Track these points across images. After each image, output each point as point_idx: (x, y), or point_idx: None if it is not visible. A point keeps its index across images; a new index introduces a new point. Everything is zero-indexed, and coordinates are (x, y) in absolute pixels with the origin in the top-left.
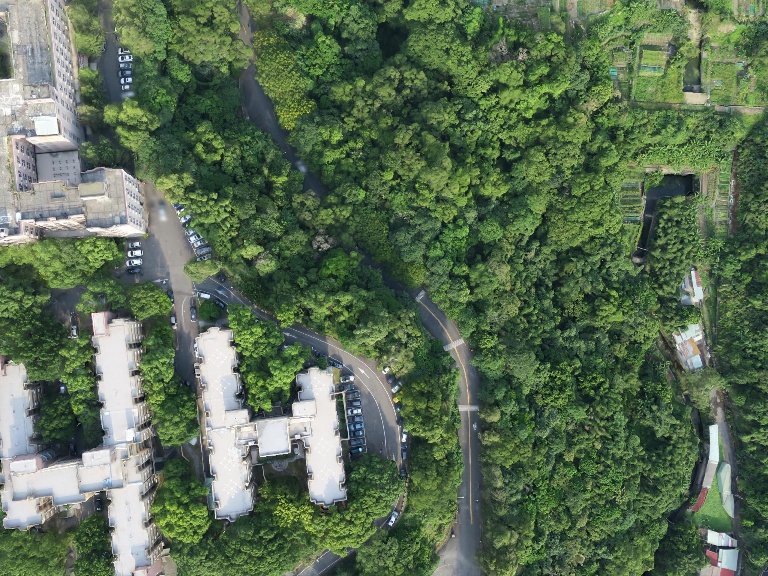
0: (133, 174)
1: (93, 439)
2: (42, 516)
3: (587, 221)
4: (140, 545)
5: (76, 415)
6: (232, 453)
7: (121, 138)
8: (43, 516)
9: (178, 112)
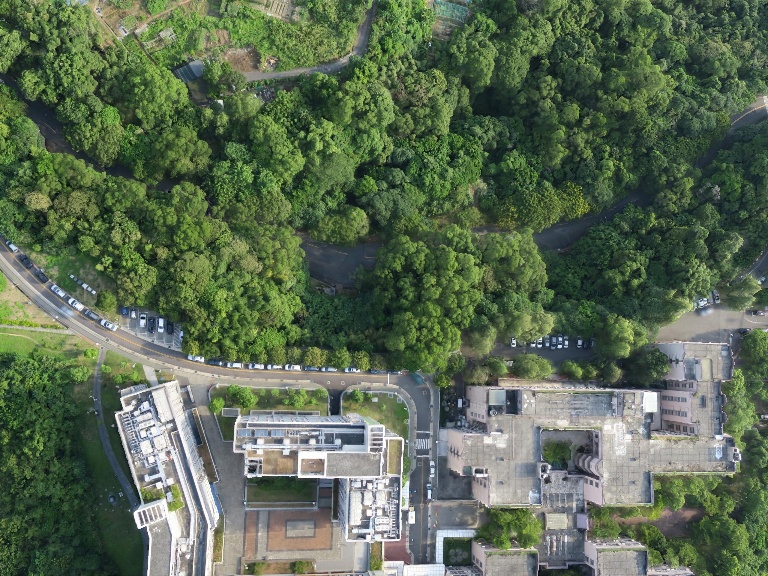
0: None
1: None
2: None
3: None
4: None
5: None
6: None
7: None
8: None
9: None
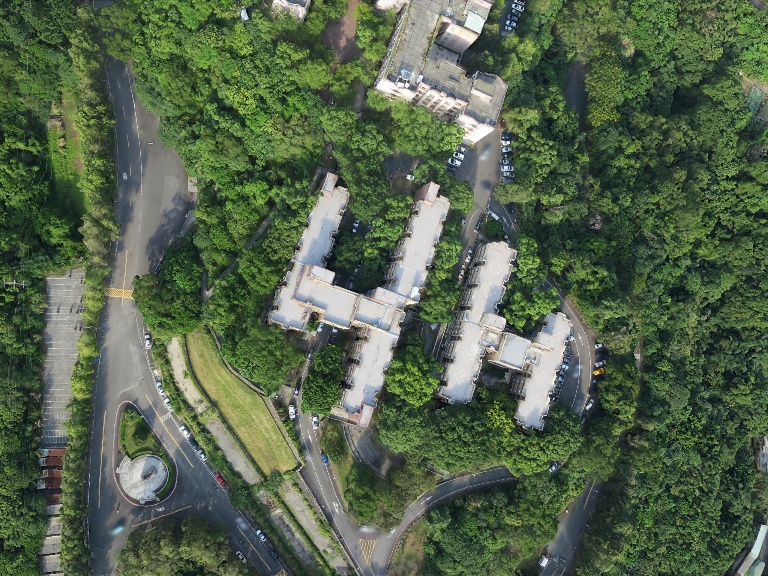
0: None
1: (369, 283)
2: (304, 324)
3: (761, 312)
4: (373, 386)
5: (363, 257)
6: (474, 348)
7: (512, 63)
8: (304, 324)
9: None
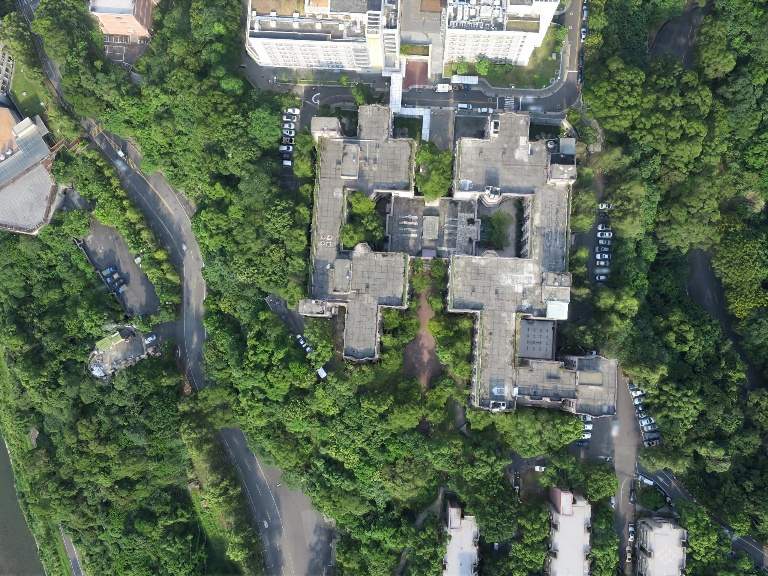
0: (598, 350)
1: None
2: None
3: None
4: None
5: None
6: None
7: (614, 326)
8: None
9: None
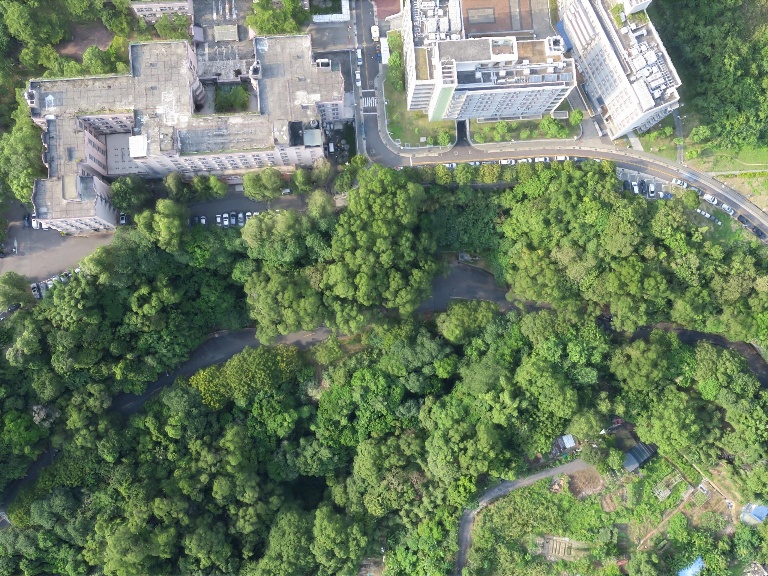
0: None
1: None
2: None
3: None
4: None
5: None
6: None
7: (137, 215)
8: None
9: (200, 268)
